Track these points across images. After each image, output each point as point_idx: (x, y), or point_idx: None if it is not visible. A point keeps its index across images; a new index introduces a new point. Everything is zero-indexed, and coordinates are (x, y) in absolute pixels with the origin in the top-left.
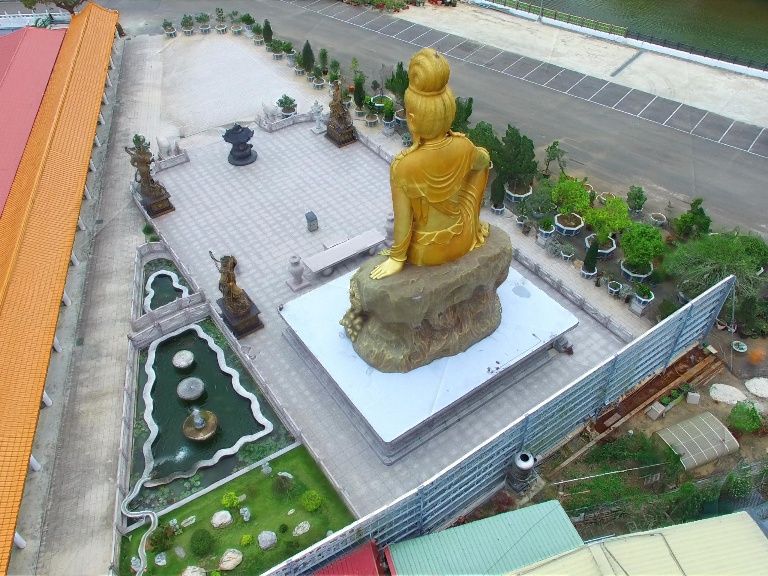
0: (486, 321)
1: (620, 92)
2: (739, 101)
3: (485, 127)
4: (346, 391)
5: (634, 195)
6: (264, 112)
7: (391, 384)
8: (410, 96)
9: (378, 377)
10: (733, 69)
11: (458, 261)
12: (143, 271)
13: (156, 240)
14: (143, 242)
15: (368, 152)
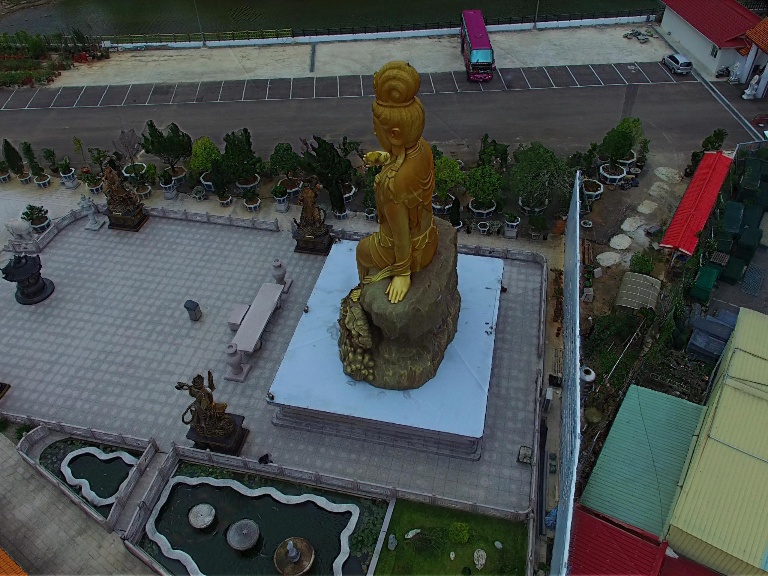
0: (456, 297)
1: (331, 82)
2: (418, 58)
3: (285, 148)
4: (407, 423)
5: (434, 153)
6: (13, 235)
7: (434, 393)
8: (390, 112)
9: (418, 395)
10: (391, 36)
11: (439, 252)
12: (45, 470)
13: (27, 429)
14: (7, 442)
15: (172, 222)
